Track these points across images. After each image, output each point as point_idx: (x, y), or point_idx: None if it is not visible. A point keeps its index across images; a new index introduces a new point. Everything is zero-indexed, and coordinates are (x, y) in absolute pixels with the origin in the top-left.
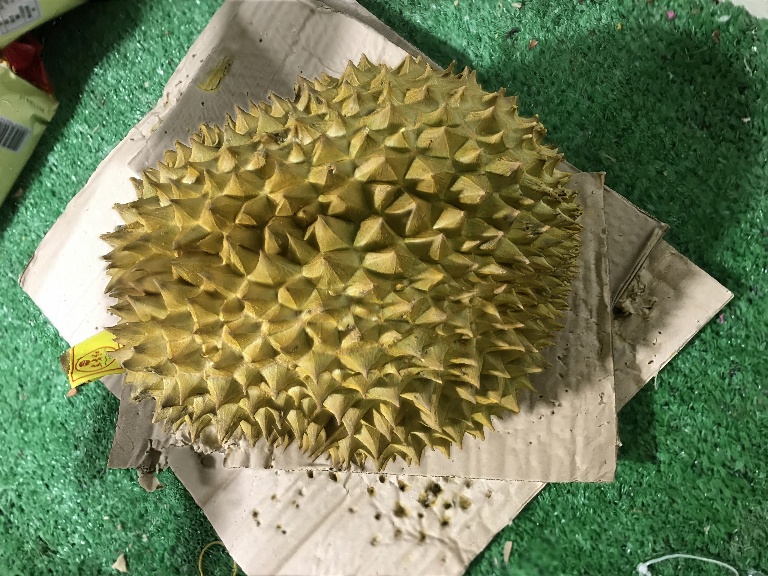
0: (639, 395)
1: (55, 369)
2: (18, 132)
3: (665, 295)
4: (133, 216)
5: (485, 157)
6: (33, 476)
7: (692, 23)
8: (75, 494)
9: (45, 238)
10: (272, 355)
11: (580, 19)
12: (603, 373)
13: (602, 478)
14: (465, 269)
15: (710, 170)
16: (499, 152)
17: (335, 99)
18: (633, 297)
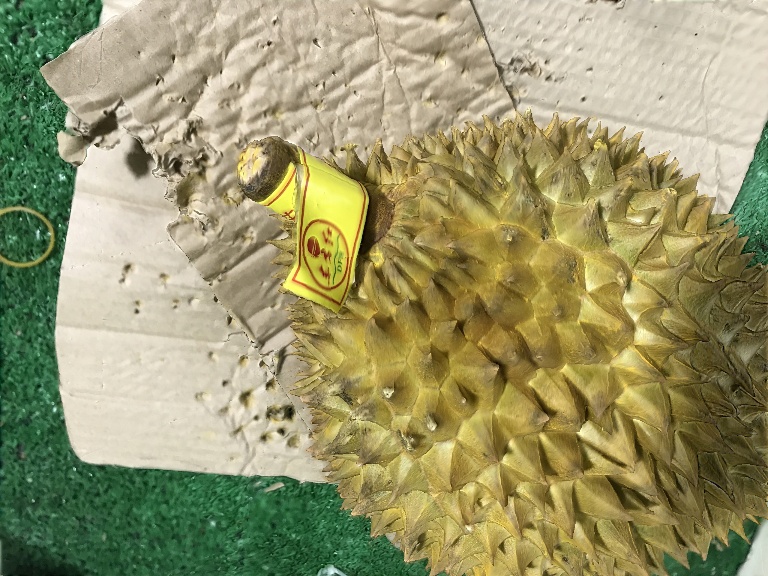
0: None
1: None
2: None
3: None
4: (587, 245)
5: None
6: None
7: None
8: None
9: None
10: None
11: None
12: None
13: (396, 543)
14: None
15: None
16: None
17: None
18: None
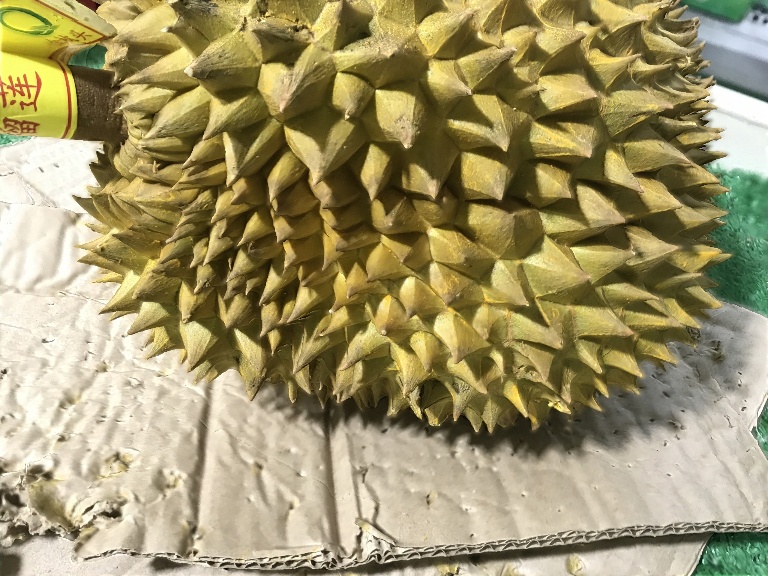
0: None
1: None
2: None
3: (726, 336)
4: None
5: None
6: None
7: None
8: None
9: None
10: None
11: None
12: (713, 395)
13: None
14: (679, 25)
15: None
16: None
17: None
18: None
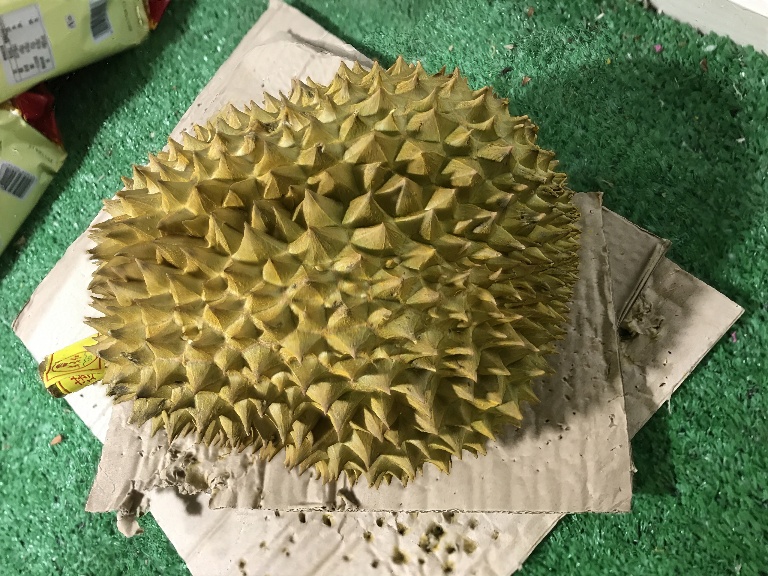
0: (652, 421)
1: (41, 416)
2: (25, 179)
3: (672, 313)
4: (121, 210)
5: (476, 143)
6: (8, 533)
7: (679, 54)
8: (51, 551)
9: (42, 282)
10: (255, 335)
11: (570, 56)
12: (612, 394)
13: (617, 507)
14: (458, 249)
15: (709, 190)
16: (491, 140)
17: (326, 92)
18: (639, 317)
